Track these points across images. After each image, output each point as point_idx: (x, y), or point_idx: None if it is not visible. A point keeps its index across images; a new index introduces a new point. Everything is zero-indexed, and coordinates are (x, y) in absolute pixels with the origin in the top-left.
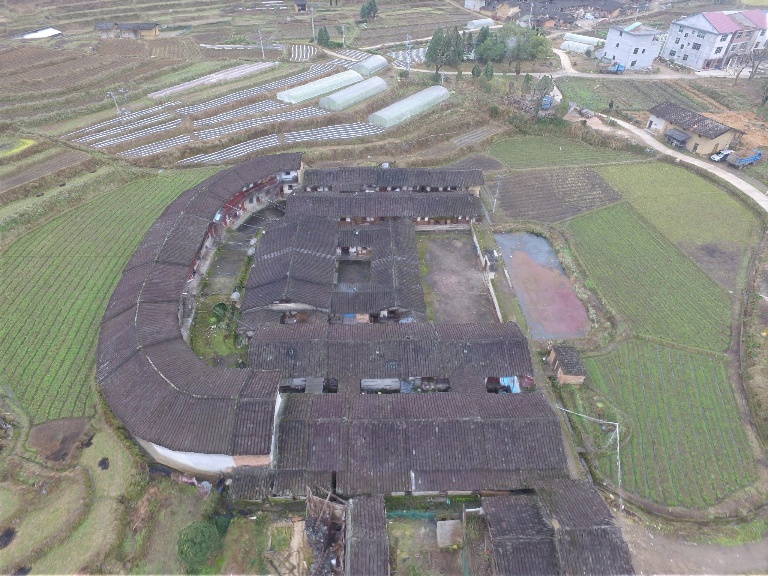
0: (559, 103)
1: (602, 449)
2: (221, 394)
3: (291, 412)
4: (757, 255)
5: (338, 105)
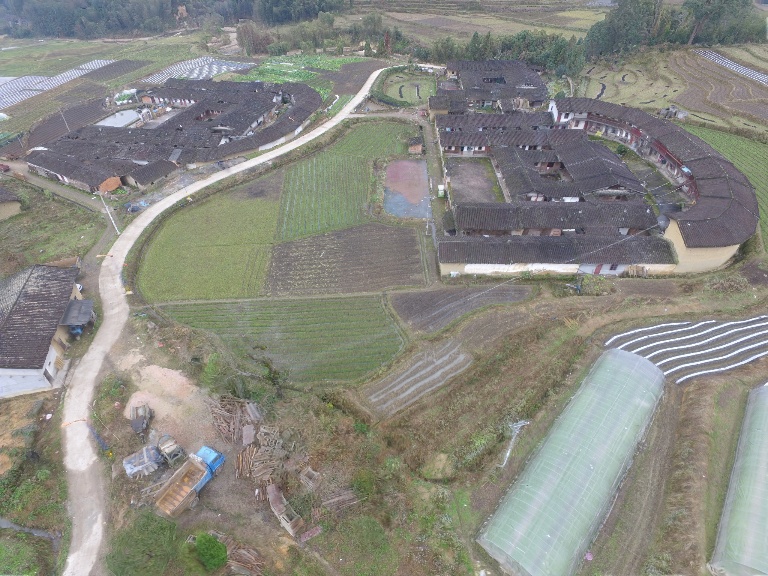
0: (102, 571)
1: (413, 130)
2: (577, 99)
3: (548, 115)
4: (230, 187)
5: (760, 388)
